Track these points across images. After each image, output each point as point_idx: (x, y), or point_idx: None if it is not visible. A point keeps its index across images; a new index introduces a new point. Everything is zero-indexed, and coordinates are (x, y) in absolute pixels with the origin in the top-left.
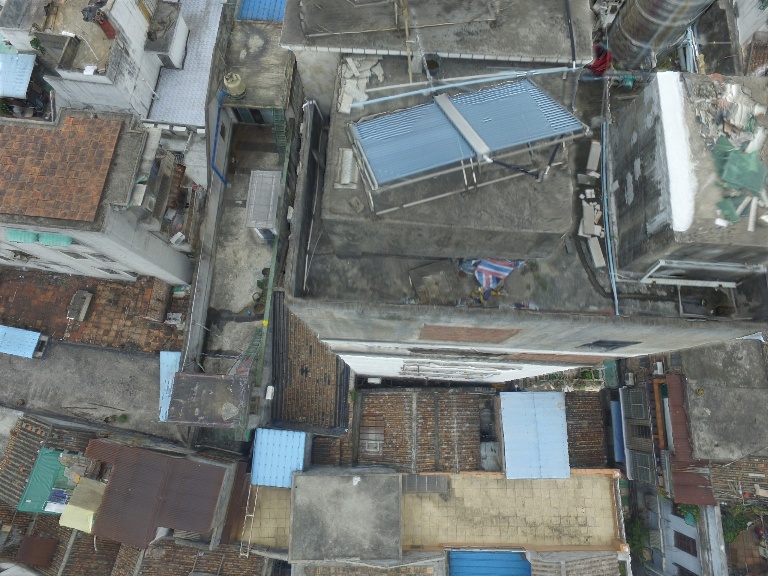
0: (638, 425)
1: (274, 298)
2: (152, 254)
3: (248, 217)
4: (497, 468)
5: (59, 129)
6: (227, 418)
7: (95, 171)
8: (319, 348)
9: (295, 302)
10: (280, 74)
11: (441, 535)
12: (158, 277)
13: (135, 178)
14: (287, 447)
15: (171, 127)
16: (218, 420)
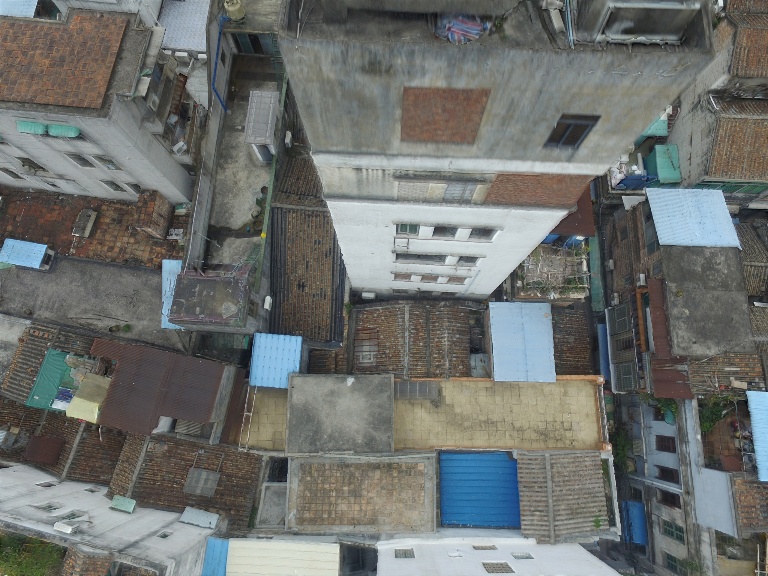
0: (622, 338)
1: (272, 214)
2: (155, 158)
3: (247, 134)
4: (486, 377)
5: (67, 27)
6: (227, 316)
7: (102, 64)
8: (315, 263)
9: (287, 39)
10: (278, 2)
11: (432, 438)
12: (160, 192)
13: (140, 71)
14: (284, 350)
15: (173, 53)
16: (218, 318)
